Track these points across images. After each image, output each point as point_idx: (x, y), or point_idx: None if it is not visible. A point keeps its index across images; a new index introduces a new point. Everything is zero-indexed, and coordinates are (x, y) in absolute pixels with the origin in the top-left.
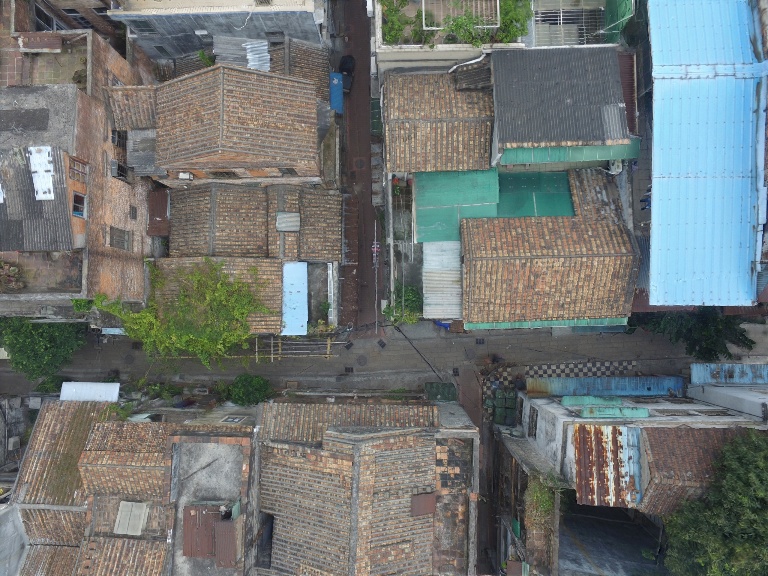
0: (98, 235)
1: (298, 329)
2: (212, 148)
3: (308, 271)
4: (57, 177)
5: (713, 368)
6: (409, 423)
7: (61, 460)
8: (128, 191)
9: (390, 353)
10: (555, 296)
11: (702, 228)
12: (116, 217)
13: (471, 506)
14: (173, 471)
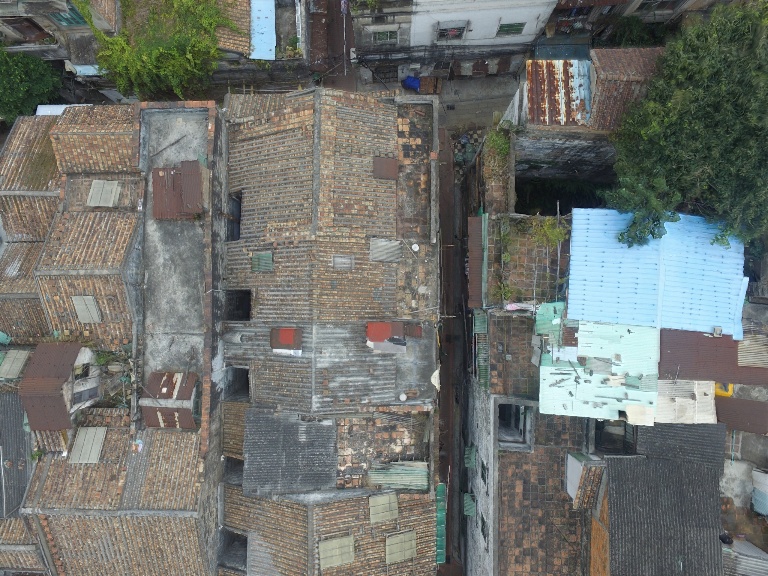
0: None
1: (266, 53)
2: None
3: (277, 15)
4: None
5: None
6: None
7: (36, 158)
8: None
9: None
10: None
11: None
12: None
13: (431, 165)
14: (142, 140)
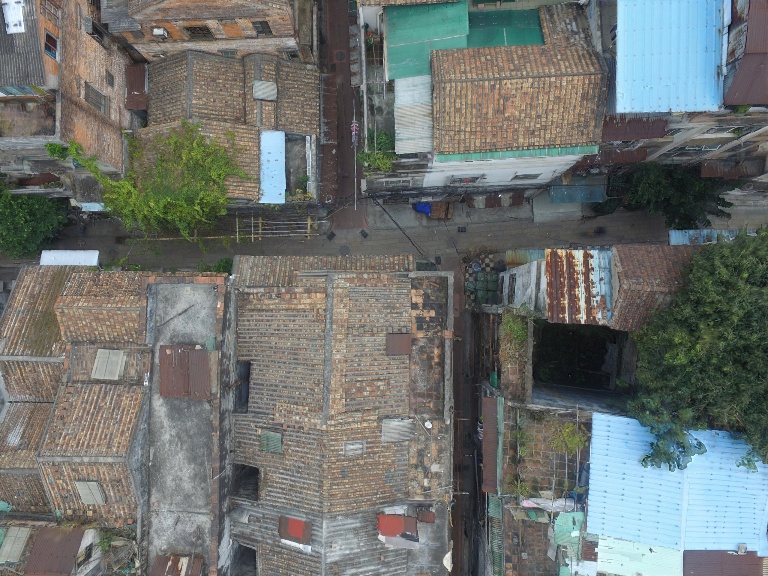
0: (72, 84)
1: (276, 197)
2: None
3: (287, 148)
4: (27, 9)
5: (692, 234)
6: (384, 269)
7: (40, 317)
8: (104, 55)
9: (372, 243)
10: (525, 122)
11: (668, 34)
12: (91, 75)
13: (446, 344)
14: (149, 314)
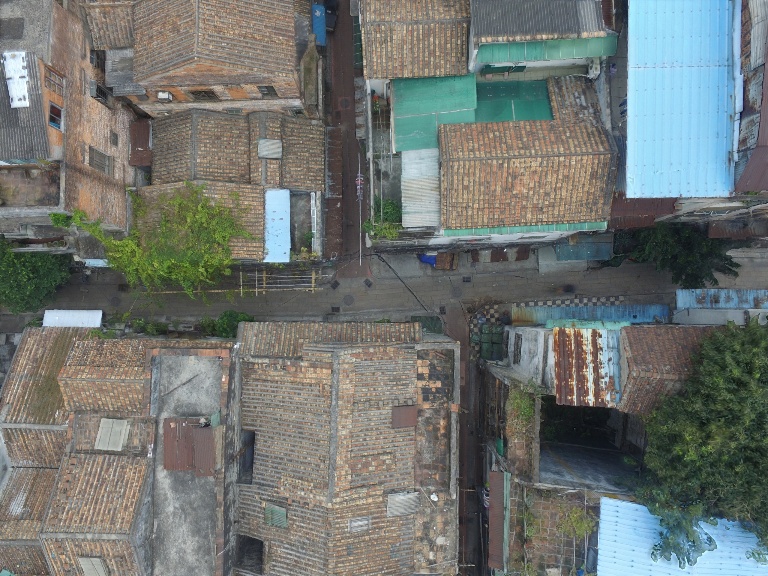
0: (76, 151)
1: (281, 256)
2: (188, 57)
3: (292, 203)
4: (32, 83)
5: (699, 293)
6: (390, 338)
7: (43, 382)
8: (108, 116)
9: (377, 292)
10: (533, 199)
11: (679, 119)
12: (95, 138)
13: (452, 417)
14: (153, 385)
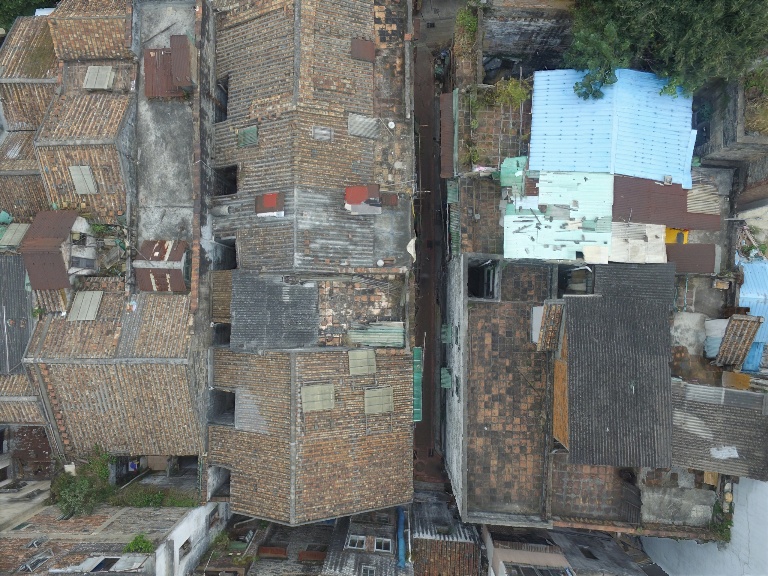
0: None
1: None
2: None
3: None
4: None
5: None
6: None
7: (34, 51)
8: None
9: None
10: None
11: None
12: None
13: (406, 46)
14: (134, 25)
